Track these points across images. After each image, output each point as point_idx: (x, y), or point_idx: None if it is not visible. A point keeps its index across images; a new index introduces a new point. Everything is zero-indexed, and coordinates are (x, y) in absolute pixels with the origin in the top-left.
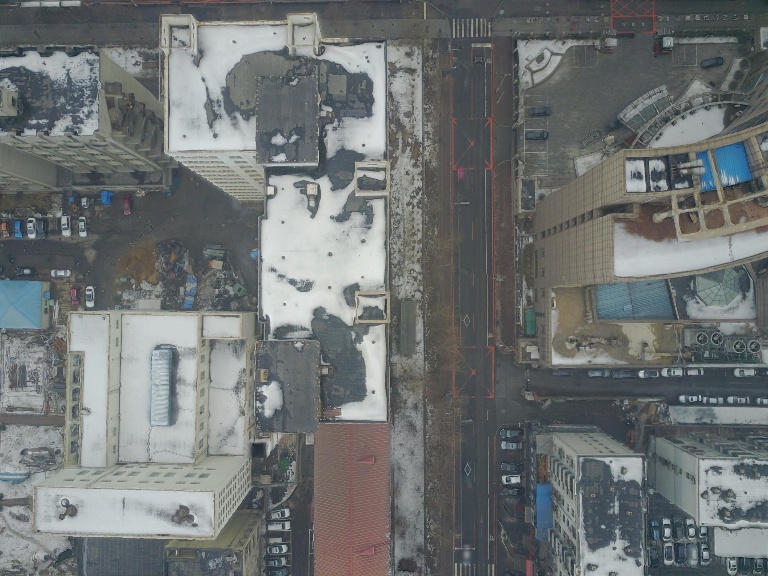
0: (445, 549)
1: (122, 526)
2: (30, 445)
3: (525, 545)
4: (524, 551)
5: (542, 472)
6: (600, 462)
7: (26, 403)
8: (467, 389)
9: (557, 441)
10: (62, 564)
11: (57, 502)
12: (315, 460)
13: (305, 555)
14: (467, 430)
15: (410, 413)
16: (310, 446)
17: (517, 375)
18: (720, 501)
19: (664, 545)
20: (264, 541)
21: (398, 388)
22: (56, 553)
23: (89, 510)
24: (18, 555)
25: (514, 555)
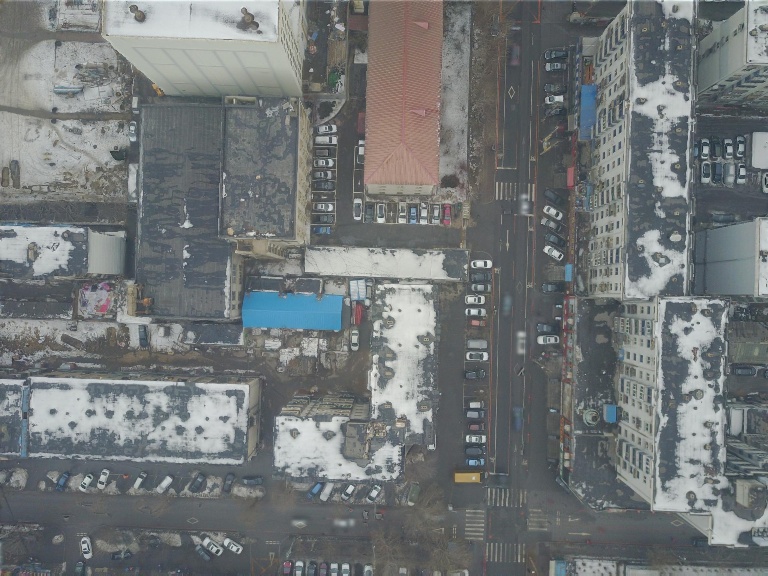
0: (487, 168)
1: (188, 31)
2: (84, 61)
3: (565, 164)
4: (564, 170)
5: (586, 80)
6: (652, 1)
7: (81, 21)
8: (514, 14)
9: (604, 32)
10: (113, 176)
11: (126, 8)
12: (369, 32)
13: (350, 171)
14: (512, 52)
15: (457, 36)
16: (358, 65)
17: (563, 1)
18: (767, 38)
19: (702, 163)
20: (310, 157)
21: (446, 12)
22: (107, 166)
23: (157, 16)
24: (70, 167)
25: (554, 174)
